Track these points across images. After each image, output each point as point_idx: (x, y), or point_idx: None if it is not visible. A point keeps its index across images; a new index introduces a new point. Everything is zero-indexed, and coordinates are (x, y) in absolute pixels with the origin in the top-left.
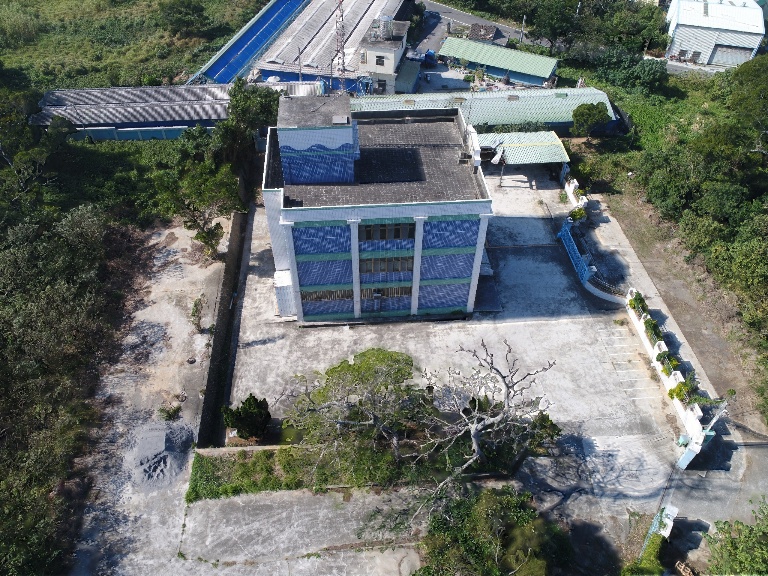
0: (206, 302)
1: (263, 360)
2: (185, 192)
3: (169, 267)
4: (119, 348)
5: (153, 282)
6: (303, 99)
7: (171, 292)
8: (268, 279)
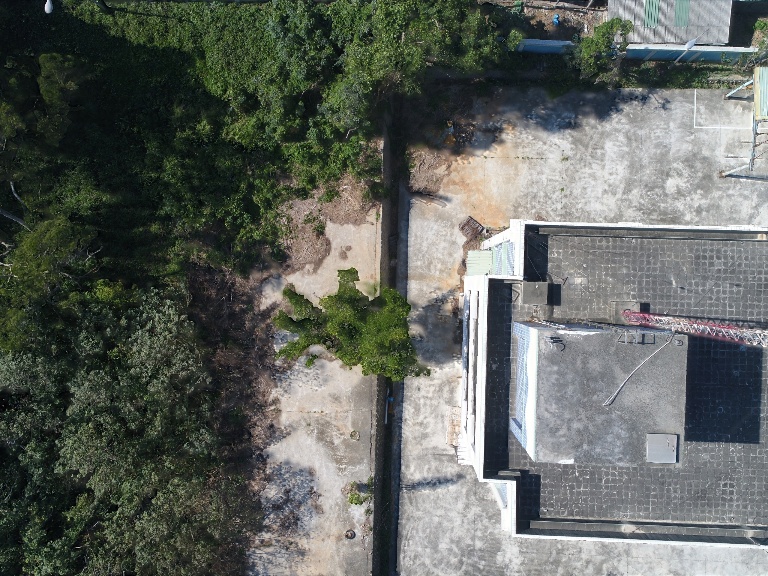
0: (358, 438)
1: (433, 515)
2: (298, 184)
3: (298, 363)
4: (259, 509)
5: (281, 392)
6: (588, 350)
7: (308, 414)
8: (435, 370)
